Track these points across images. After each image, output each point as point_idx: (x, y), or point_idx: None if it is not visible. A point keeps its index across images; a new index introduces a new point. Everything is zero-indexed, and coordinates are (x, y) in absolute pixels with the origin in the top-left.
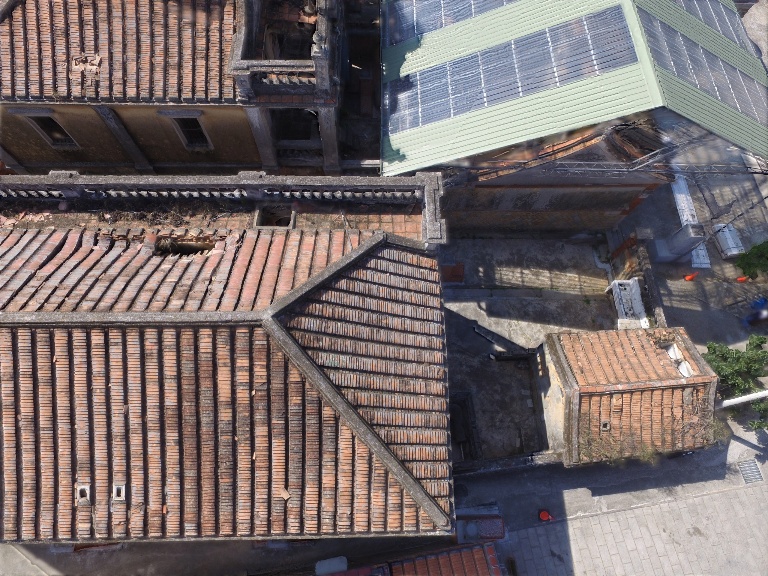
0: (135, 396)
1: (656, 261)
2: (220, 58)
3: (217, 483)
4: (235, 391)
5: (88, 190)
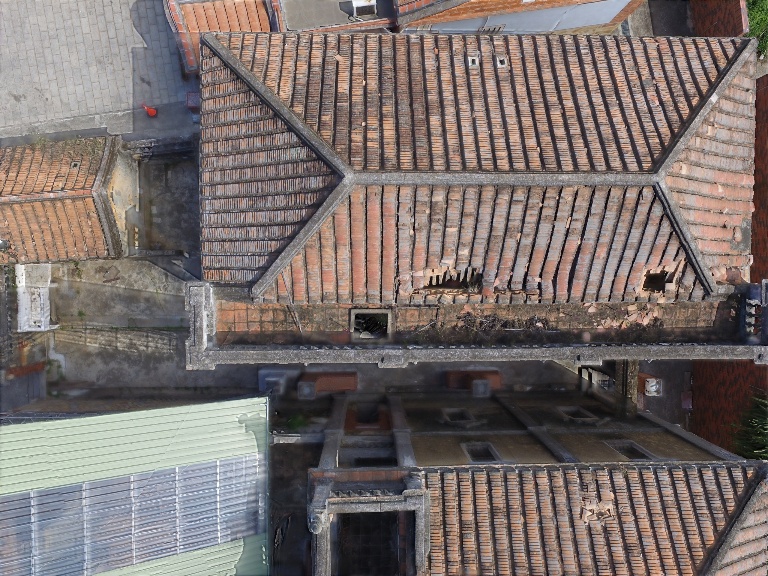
0: (466, 123)
1: None
2: (445, 525)
3: (395, 66)
4: (380, 126)
5: None
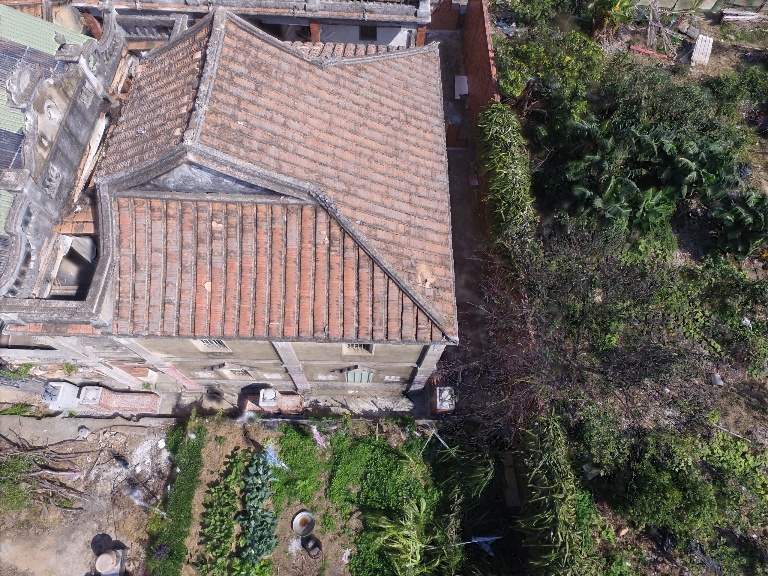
0: None
1: None
2: None
3: None
4: None
5: (306, 5)
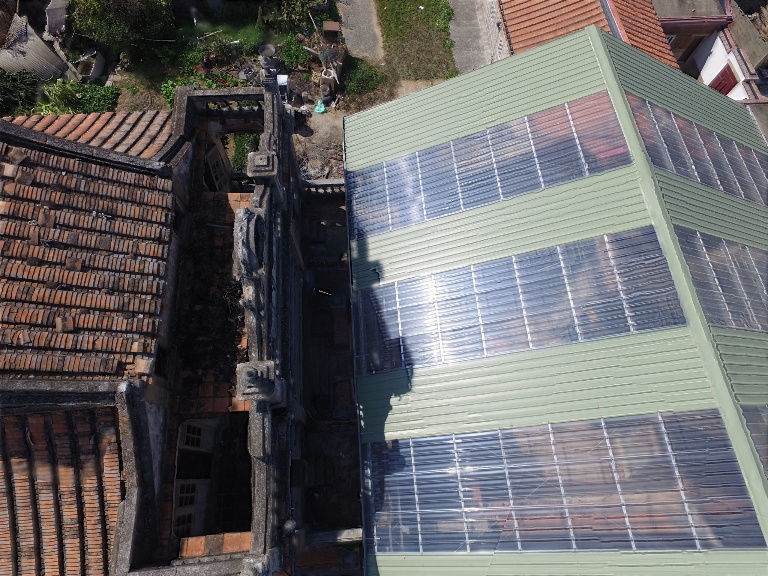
0: None
1: None
2: (103, 530)
3: None
4: None
5: None
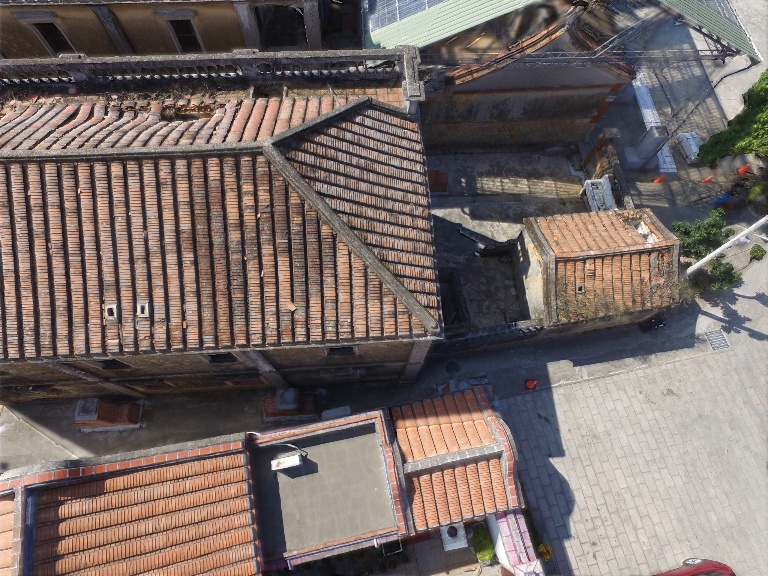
0: (153, 222)
1: (626, 168)
2: None
3: (230, 299)
4: (242, 215)
5: None
